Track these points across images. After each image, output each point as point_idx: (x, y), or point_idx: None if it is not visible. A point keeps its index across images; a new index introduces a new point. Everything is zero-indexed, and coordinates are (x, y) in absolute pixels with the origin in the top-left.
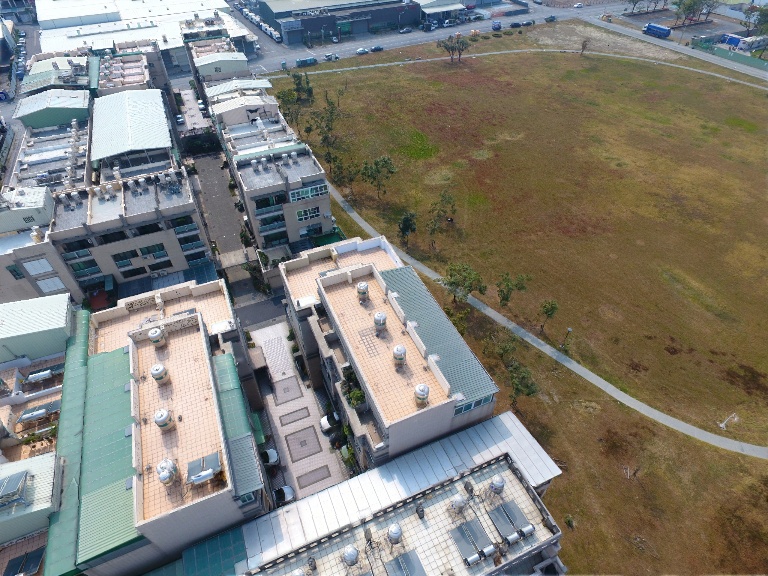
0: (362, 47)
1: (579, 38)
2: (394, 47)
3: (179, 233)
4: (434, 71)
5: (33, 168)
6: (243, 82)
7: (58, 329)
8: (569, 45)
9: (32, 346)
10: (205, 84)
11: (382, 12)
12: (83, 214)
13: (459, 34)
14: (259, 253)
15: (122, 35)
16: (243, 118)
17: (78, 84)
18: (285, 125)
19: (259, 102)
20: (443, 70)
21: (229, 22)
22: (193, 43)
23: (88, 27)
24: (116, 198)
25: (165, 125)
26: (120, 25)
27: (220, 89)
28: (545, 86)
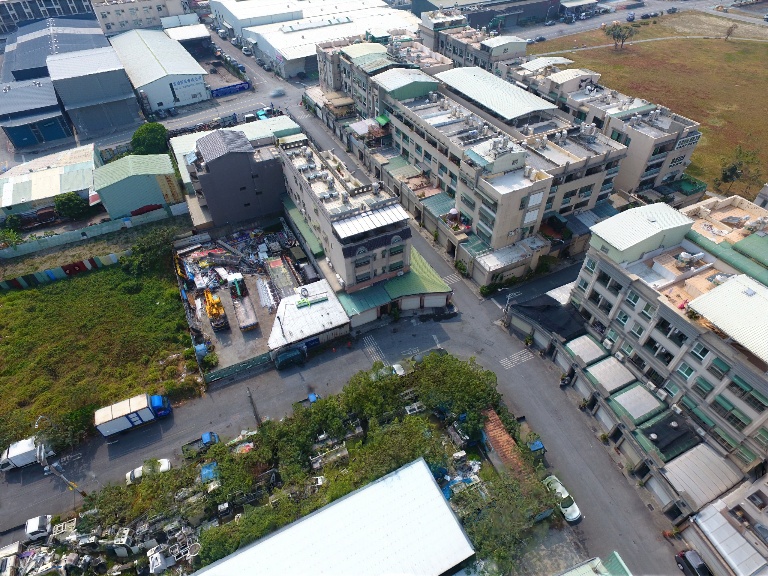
0: (524, 38)
1: (710, 26)
2: (553, 37)
3: (607, 175)
4: (607, 57)
5: (440, 130)
6: (549, 59)
7: (691, 224)
8: (706, 32)
9: (671, 238)
10: (501, 63)
11: (530, 6)
12: (539, 159)
13: (605, 25)
14: (637, 196)
15: (329, 30)
16: (574, 87)
17: (409, 64)
18: (616, 92)
19: (587, 73)
20: (614, 56)
21: (412, 17)
22: (442, 31)
23: (285, 24)
24: (548, 148)
25: (528, 92)
26: (323, 21)
27: (536, 65)
28: (717, 66)
